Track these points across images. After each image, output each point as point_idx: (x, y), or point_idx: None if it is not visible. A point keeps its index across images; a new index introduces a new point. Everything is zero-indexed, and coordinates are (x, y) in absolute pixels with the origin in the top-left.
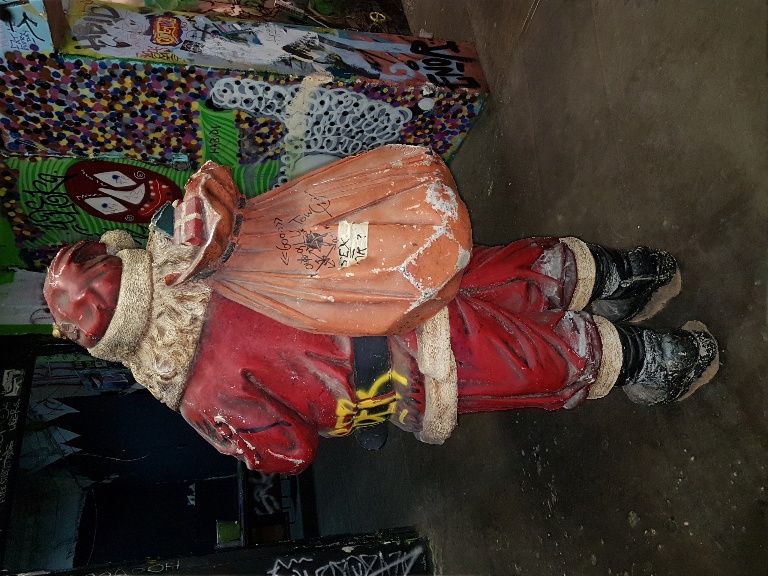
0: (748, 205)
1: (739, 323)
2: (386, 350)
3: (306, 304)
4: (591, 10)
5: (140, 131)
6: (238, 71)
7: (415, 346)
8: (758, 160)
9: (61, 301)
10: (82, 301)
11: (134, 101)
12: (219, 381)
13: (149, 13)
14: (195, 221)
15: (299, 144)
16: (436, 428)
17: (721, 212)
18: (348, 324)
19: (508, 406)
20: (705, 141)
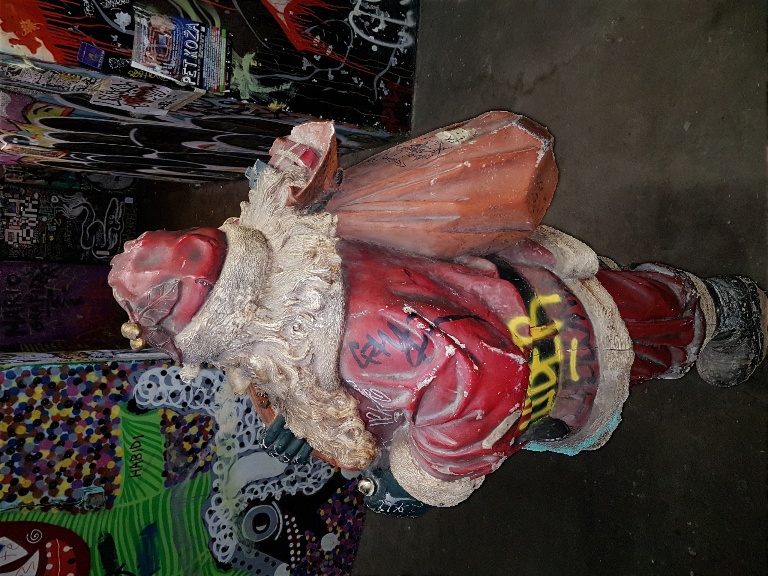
0: (674, 192)
1: (745, 257)
2: (520, 276)
3: (440, 190)
4: None
5: (44, 462)
6: (163, 360)
7: (547, 251)
8: (656, 167)
9: (149, 262)
10: (184, 243)
11: (42, 418)
12: (385, 282)
13: (48, 353)
14: (302, 144)
15: (231, 443)
16: (616, 346)
17: (660, 216)
18: (490, 196)
19: (653, 342)
20: (609, 195)
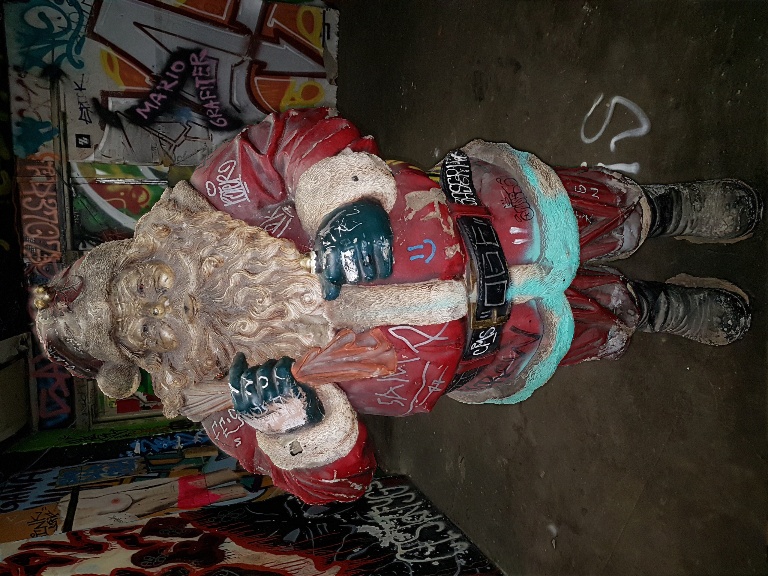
0: None
1: None
2: None
3: None
4: (606, 567)
5: None
6: None
7: None
8: None
9: None
10: None
11: None
12: None
13: None
14: None
15: None
16: None
17: None
18: None
19: None
20: None
